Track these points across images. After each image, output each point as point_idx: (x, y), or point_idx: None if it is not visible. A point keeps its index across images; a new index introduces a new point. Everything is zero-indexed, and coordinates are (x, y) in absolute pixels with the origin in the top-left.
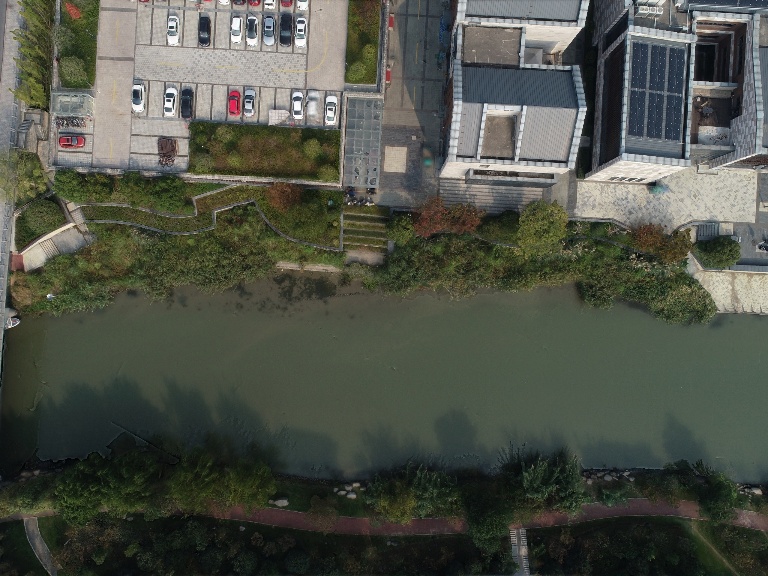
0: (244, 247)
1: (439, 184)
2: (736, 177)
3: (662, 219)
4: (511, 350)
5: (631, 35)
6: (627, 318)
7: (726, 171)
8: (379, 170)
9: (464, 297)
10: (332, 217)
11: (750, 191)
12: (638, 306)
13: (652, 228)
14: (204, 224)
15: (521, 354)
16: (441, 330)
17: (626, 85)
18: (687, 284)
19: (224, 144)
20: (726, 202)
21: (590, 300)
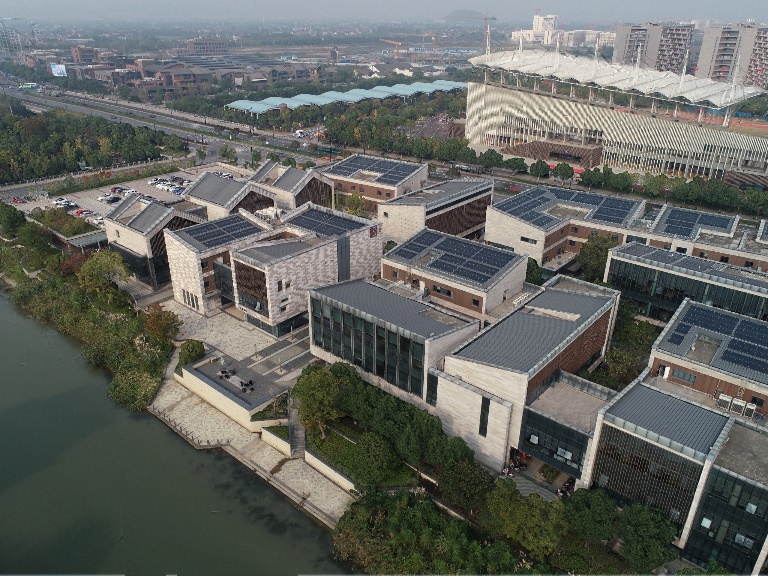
0: (0, 253)
1: (110, 272)
2: (260, 337)
3: (187, 332)
4: (7, 352)
5: (241, 214)
6: (93, 381)
7: (258, 332)
8: (90, 243)
9: (41, 330)
10: (48, 258)
11: (259, 347)
12: (109, 378)
13: (163, 311)
14: (6, 244)
15: (7, 356)
16: (0, 329)
17: (211, 221)
18: (153, 377)
19: (57, 216)
20: (236, 344)
21: (86, 347)
